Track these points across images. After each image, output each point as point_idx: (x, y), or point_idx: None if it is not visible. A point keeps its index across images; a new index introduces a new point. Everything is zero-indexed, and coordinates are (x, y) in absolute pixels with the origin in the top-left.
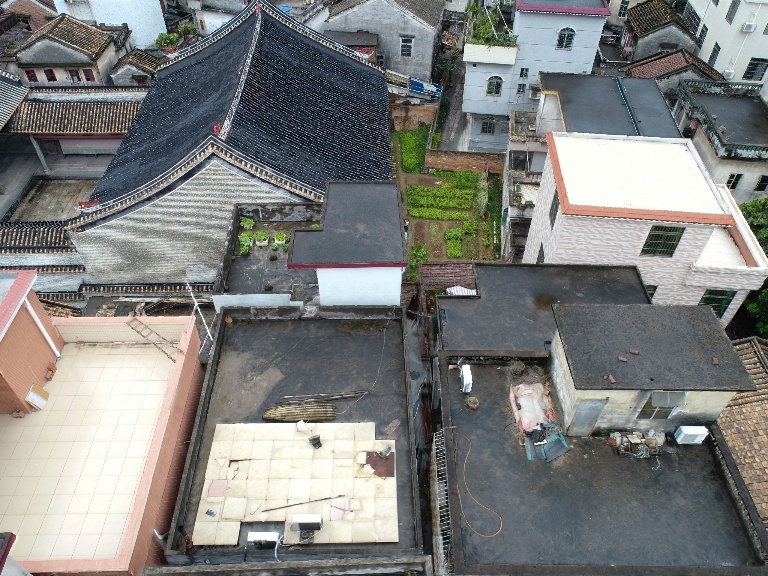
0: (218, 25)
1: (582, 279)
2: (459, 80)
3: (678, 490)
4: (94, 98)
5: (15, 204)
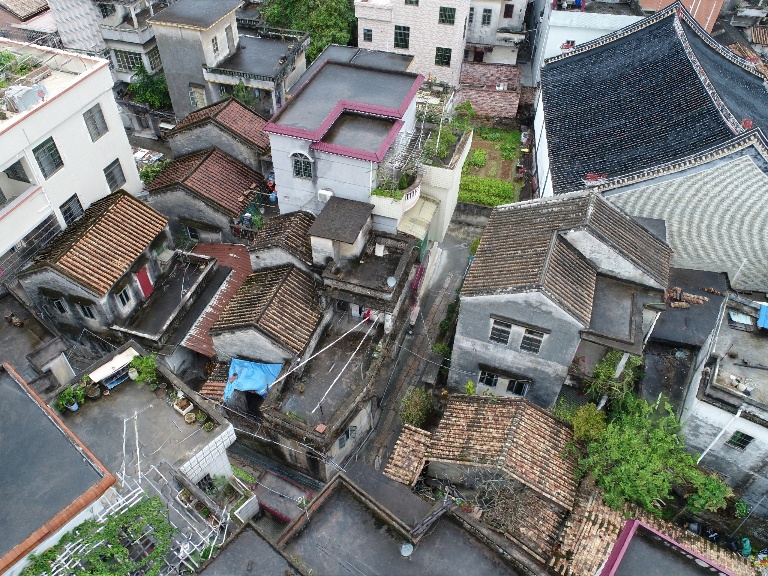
0: None
1: None
2: (398, 423)
3: None
4: None
5: None
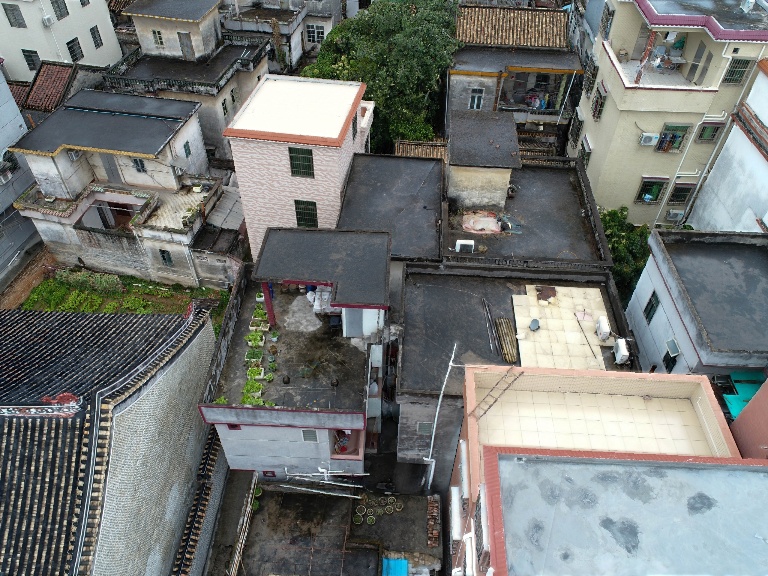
0: None
1: (362, 180)
2: None
3: (532, 183)
4: None
5: None
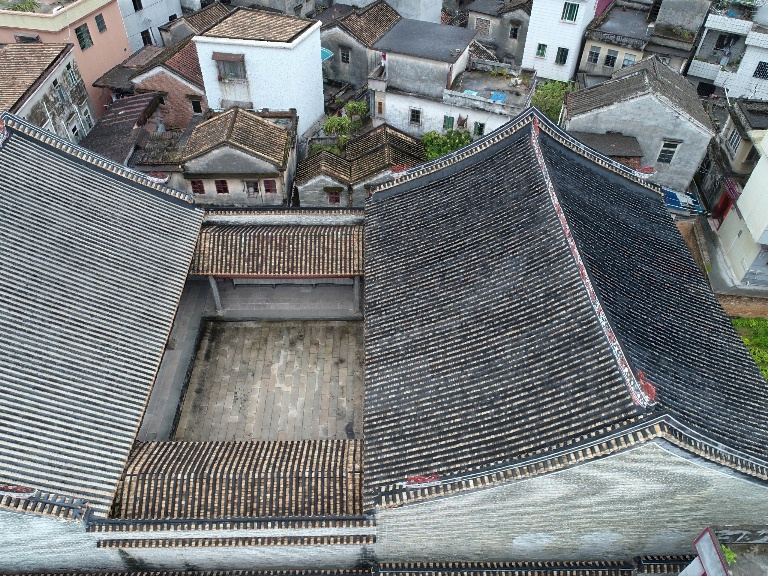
0: (403, 109)
1: None
2: None
3: None
4: (284, 221)
5: (190, 364)
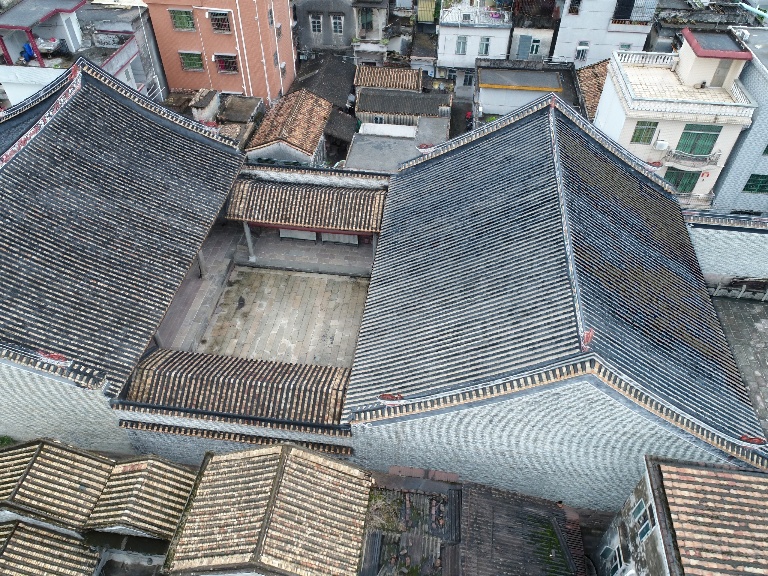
0: None
1: None
2: None
3: None
4: None
5: None
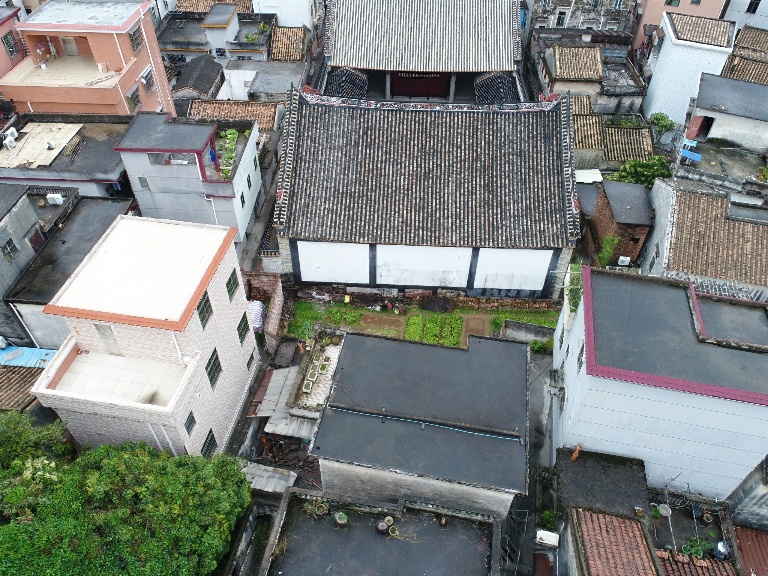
0: None
1: None
2: None
3: None
4: None
5: None
